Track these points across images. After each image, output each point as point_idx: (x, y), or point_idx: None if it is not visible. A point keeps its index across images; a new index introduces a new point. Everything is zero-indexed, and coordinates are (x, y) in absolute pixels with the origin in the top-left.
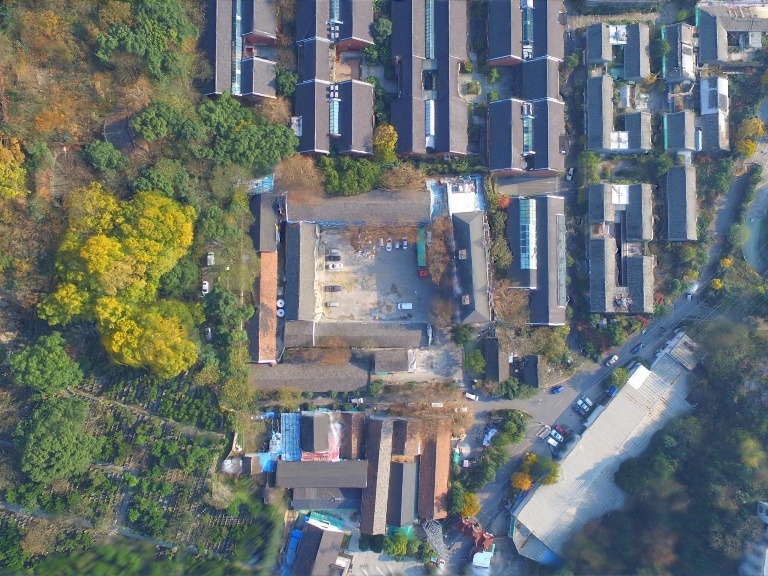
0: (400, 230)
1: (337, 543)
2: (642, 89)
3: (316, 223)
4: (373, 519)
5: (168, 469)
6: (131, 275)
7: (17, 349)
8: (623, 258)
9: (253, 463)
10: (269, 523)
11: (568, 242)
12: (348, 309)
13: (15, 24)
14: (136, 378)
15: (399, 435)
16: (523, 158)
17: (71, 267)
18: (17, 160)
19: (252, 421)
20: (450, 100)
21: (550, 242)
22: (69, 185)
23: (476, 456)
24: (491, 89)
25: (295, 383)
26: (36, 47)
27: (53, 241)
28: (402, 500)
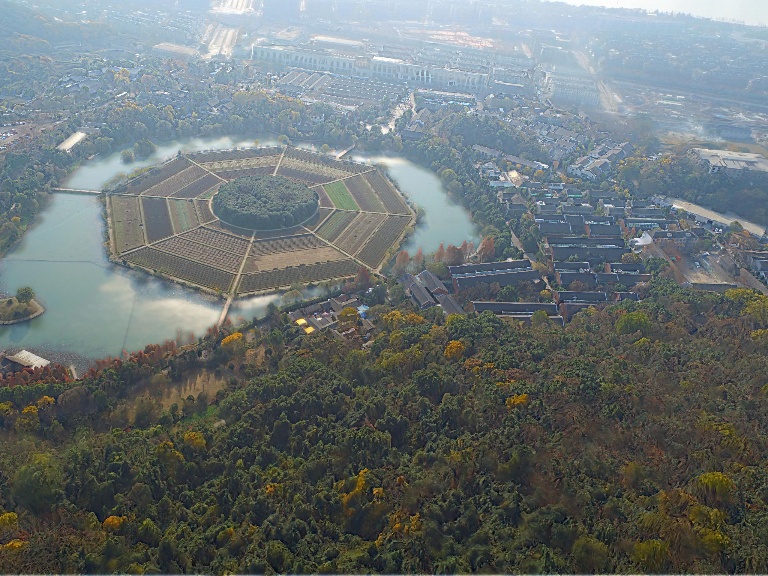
0: None
1: None
2: None
3: None
4: None
5: None
6: None
7: None
8: None
9: None
10: None
11: None
12: (713, 282)
13: None
14: None
15: None
16: None
17: None
18: None
19: None
20: None
21: None
22: None
23: (746, 248)
24: None
25: None
26: None
27: None
28: None
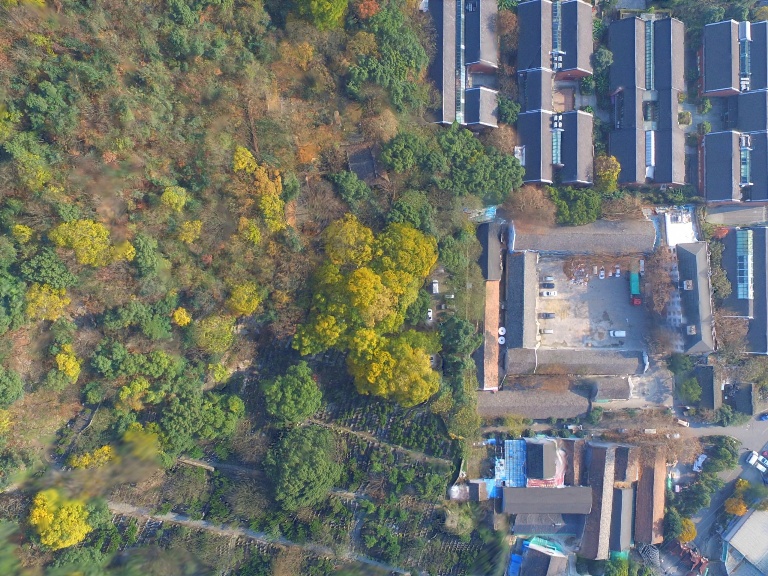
0: (618, 259)
1: (562, 568)
2: None
3: (538, 252)
4: (598, 545)
5: (401, 496)
6: (389, 307)
7: (253, 377)
8: None
9: (481, 489)
10: (498, 549)
11: None
12: (561, 336)
13: None
14: (367, 405)
15: (621, 462)
16: (740, 189)
17: (335, 299)
18: (277, 192)
19: (474, 447)
20: (673, 132)
21: (767, 272)
22: (308, 214)
23: (687, 481)
24: (701, 119)
25: (517, 410)
26: (277, 76)
27: (311, 273)
28: (621, 525)
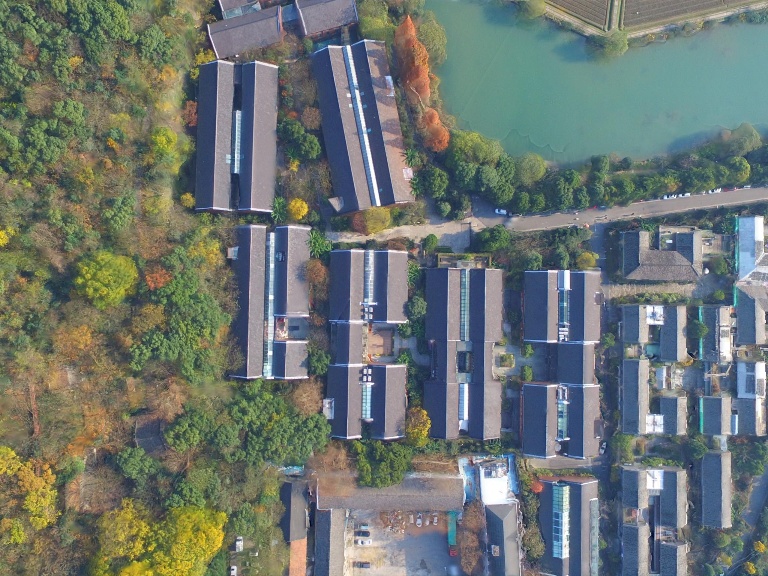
0: None
1: None
2: (678, 366)
3: None
4: None
5: None
6: None
7: None
8: (656, 541)
9: None
10: None
11: (600, 520)
12: None
13: (47, 336)
14: None
15: None
16: (557, 442)
17: None
18: (48, 483)
19: None
20: (485, 387)
21: (583, 531)
22: (98, 484)
23: None
24: (525, 361)
25: None
26: None
27: (83, 564)
28: None
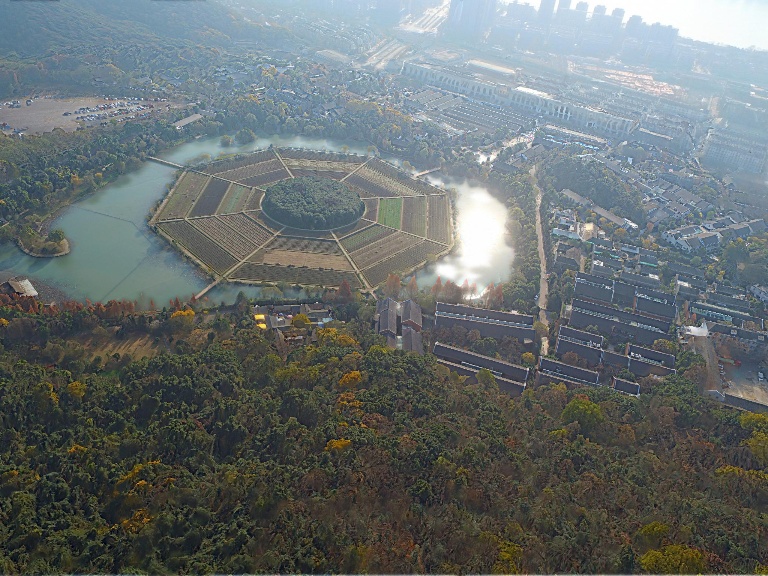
0: None
1: None
2: None
3: None
4: None
5: None
6: None
7: None
8: None
9: None
10: None
11: None
12: None
13: None
14: None
15: None
16: None
17: None
18: None
19: None
20: None
21: None
22: None
23: None
24: None
25: None
26: None
27: None
28: None
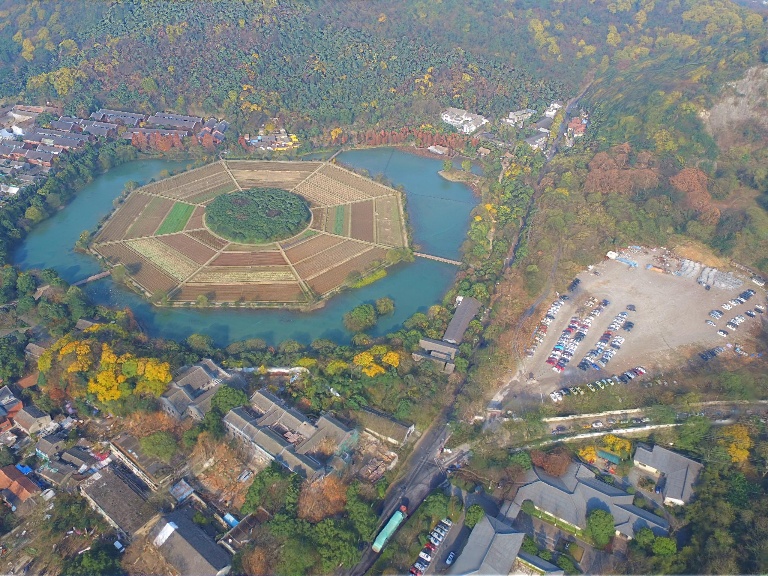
0: None
1: None
2: None
3: None
4: None
5: None
6: None
7: None
8: None
9: None
10: None
11: None
12: None
13: None
14: None
15: None
16: None
17: None
18: None
19: None
20: (43, 134)
21: None
22: None
23: None
24: None
25: None
26: None
27: None
28: None
